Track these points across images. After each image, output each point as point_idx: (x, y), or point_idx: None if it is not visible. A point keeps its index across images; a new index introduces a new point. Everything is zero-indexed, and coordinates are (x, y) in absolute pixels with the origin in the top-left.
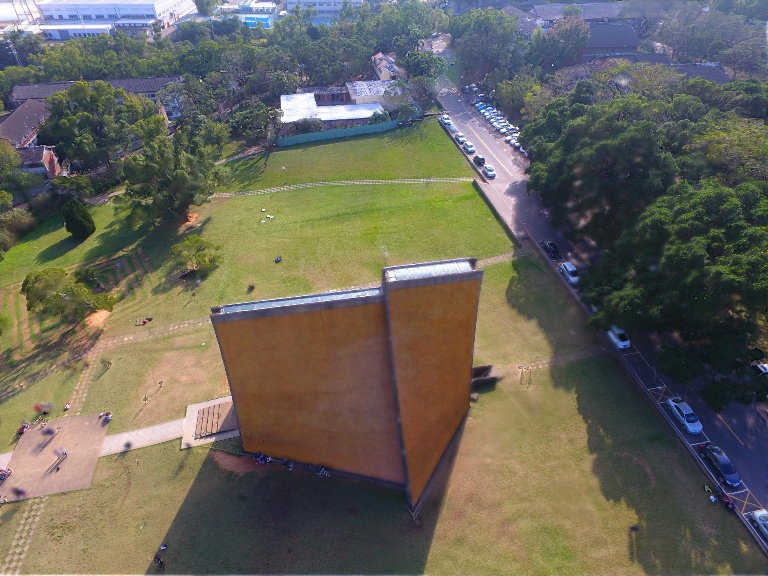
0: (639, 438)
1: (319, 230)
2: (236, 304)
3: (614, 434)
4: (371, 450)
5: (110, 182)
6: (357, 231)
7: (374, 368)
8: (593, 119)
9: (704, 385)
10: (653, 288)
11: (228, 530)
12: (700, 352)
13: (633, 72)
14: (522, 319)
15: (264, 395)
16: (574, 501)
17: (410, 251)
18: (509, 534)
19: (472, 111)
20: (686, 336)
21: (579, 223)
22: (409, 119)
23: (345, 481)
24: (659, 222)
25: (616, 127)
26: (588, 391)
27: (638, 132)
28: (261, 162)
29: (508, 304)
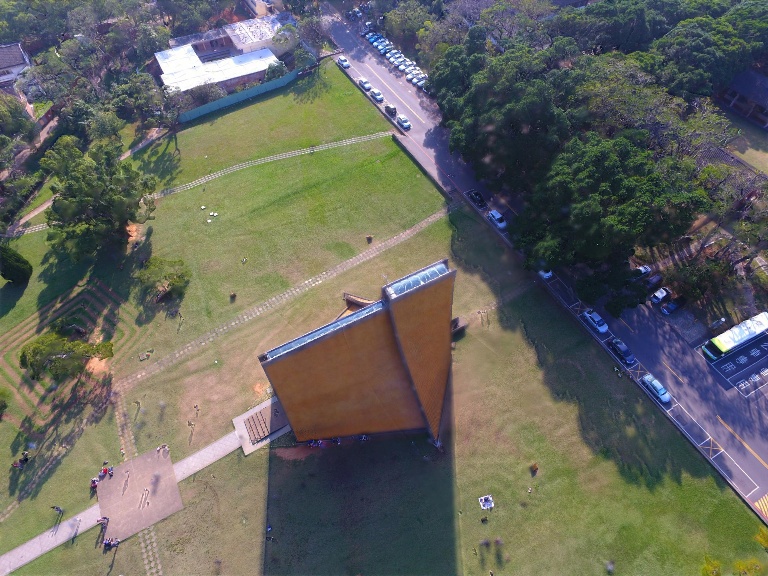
0: (570, 346)
1: (269, 219)
2: (277, 348)
3: (554, 347)
4: (396, 413)
5: (13, 206)
6: (305, 213)
7: (387, 357)
8: (494, 77)
9: (607, 300)
10: (566, 236)
11: (312, 501)
12: (602, 278)
13: (513, 5)
14: (470, 270)
15: (308, 401)
16: (538, 403)
17: (360, 224)
18: (503, 438)
19: (364, 44)
20: (591, 265)
21: (497, 175)
22: (306, 66)
23: (382, 439)
24: (564, 182)
25: (516, 89)
26: (530, 319)
27: (536, 96)
28: (172, 147)
29: (456, 258)
